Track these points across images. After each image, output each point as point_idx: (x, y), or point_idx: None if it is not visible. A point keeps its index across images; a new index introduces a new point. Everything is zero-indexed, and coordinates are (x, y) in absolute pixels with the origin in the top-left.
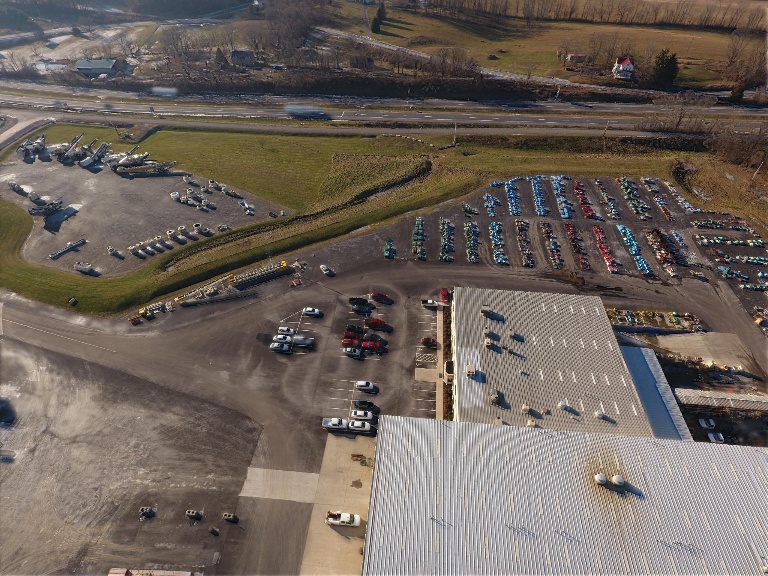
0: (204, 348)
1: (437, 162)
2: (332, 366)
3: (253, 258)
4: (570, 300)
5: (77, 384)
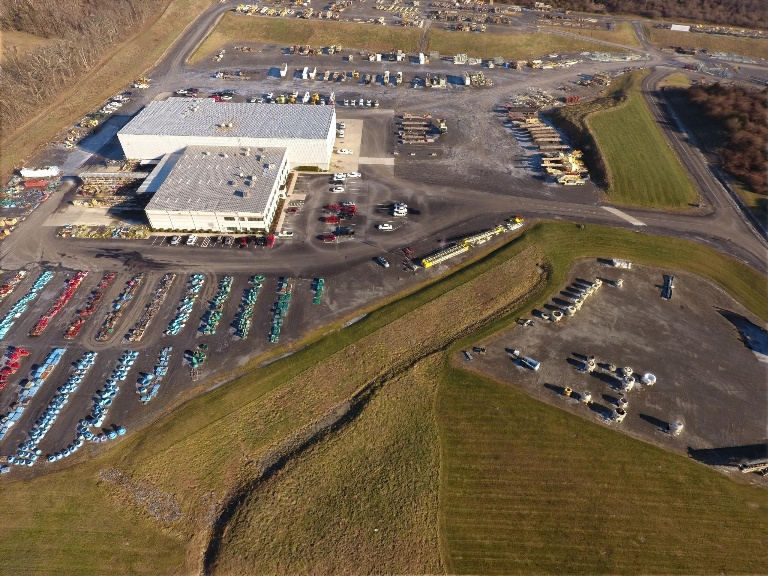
0: (453, 205)
1: (192, 552)
2: (361, 199)
3: (461, 272)
4: (172, 206)
5: (516, 189)
